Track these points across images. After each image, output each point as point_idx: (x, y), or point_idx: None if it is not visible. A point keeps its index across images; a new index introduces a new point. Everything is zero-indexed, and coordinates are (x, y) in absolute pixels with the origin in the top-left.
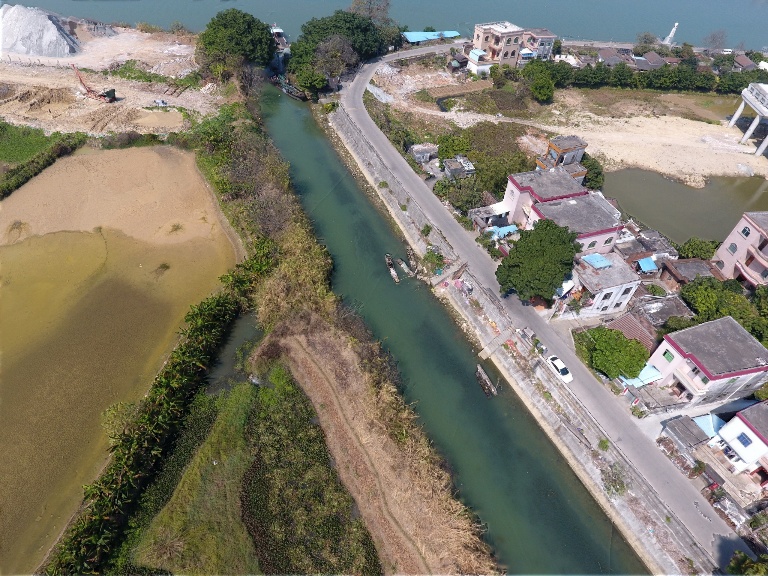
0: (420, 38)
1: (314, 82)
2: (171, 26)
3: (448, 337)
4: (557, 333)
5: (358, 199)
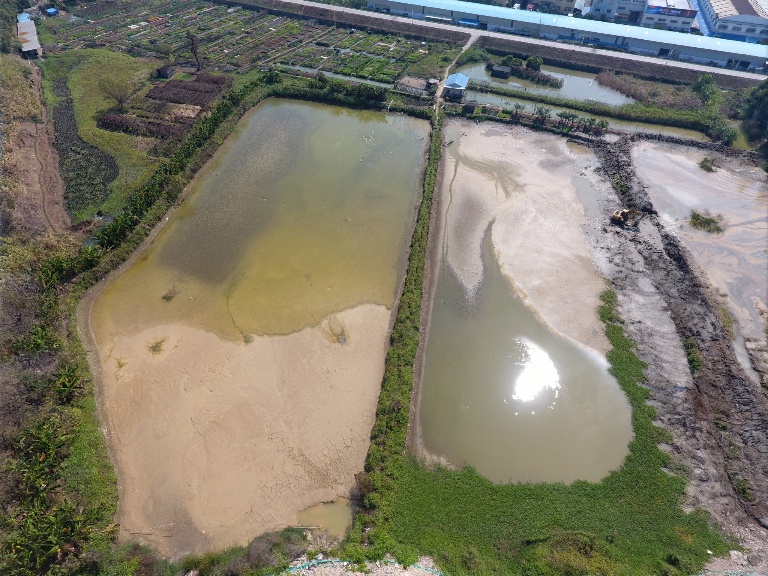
0: None
1: None
2: None
3: None
4: None
5: None
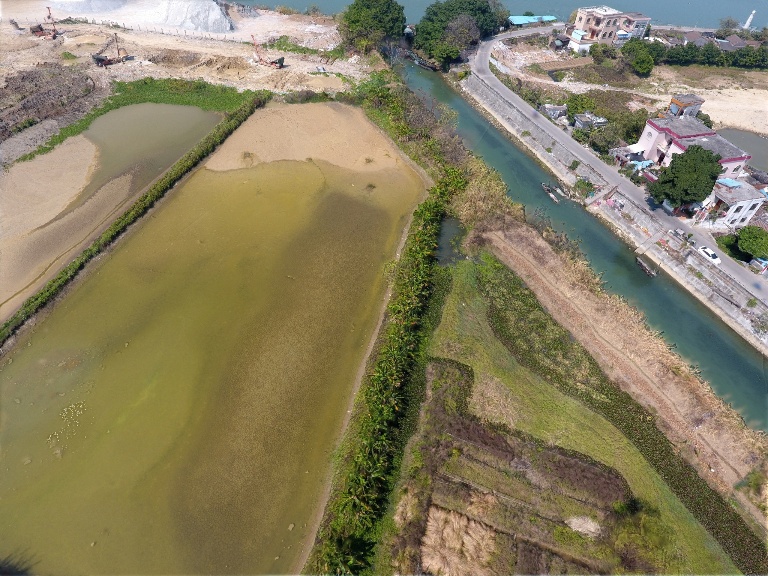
0: (523, 21)
1: (450, 53)
2: (308, 8)
3: (608, 239)
4: (700, 234)
5: (505, 145)
